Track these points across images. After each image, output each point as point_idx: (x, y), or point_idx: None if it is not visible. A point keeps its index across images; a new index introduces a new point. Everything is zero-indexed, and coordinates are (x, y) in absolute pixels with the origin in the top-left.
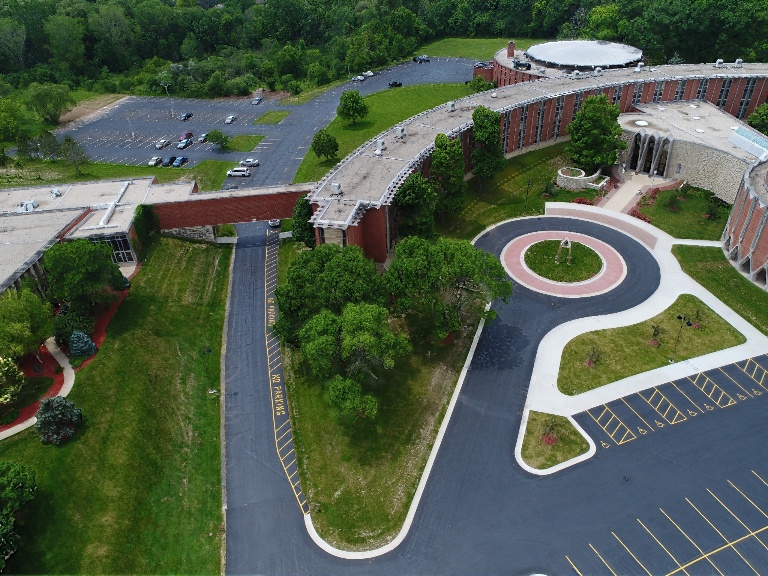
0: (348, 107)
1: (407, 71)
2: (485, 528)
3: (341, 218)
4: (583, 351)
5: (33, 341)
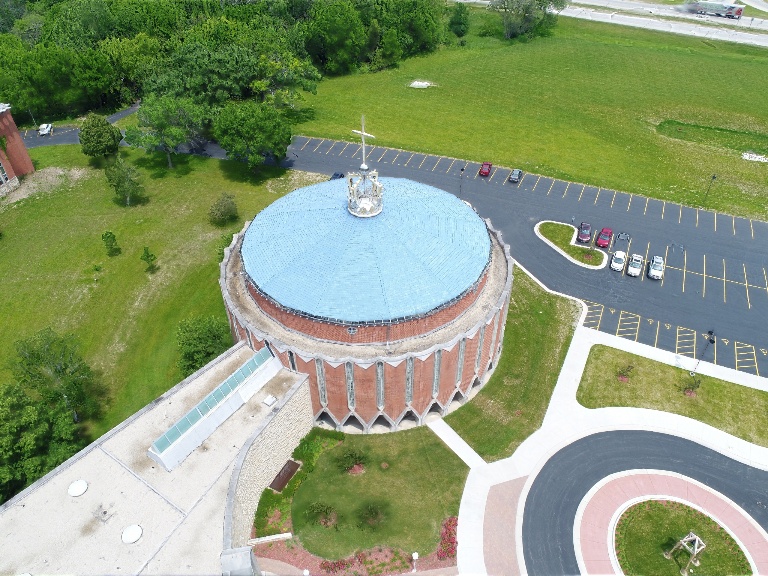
0: None
1: None
2: None
3: None
4: None
5: None
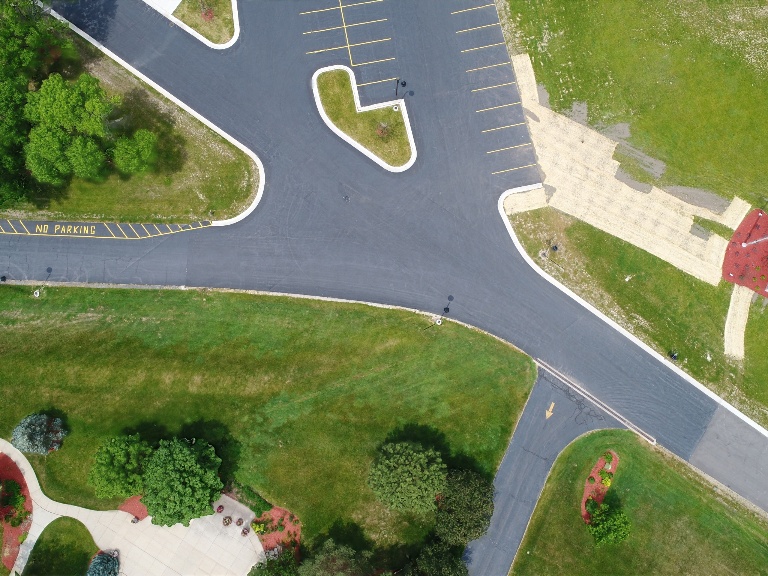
0: None
1: None
2: (268, 97)
3: None
4: None
5: None
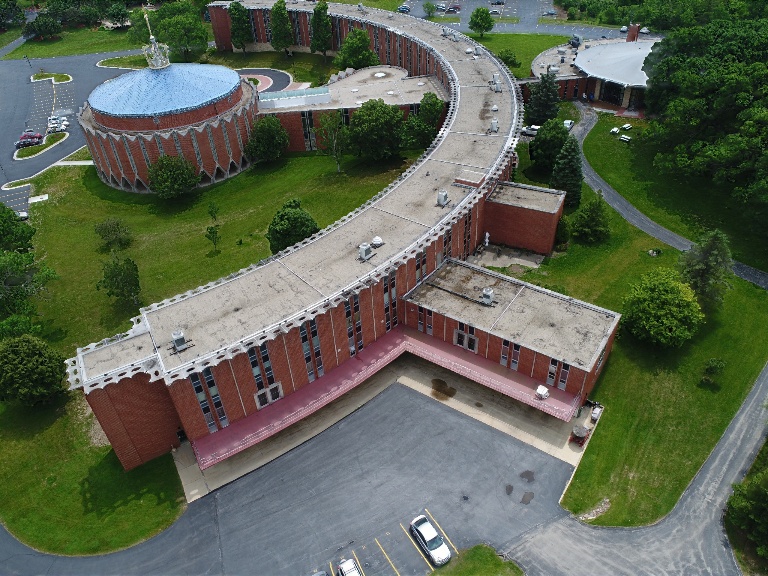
0: None
1: None
2: None
3: None
4: None
5: (200, 7)
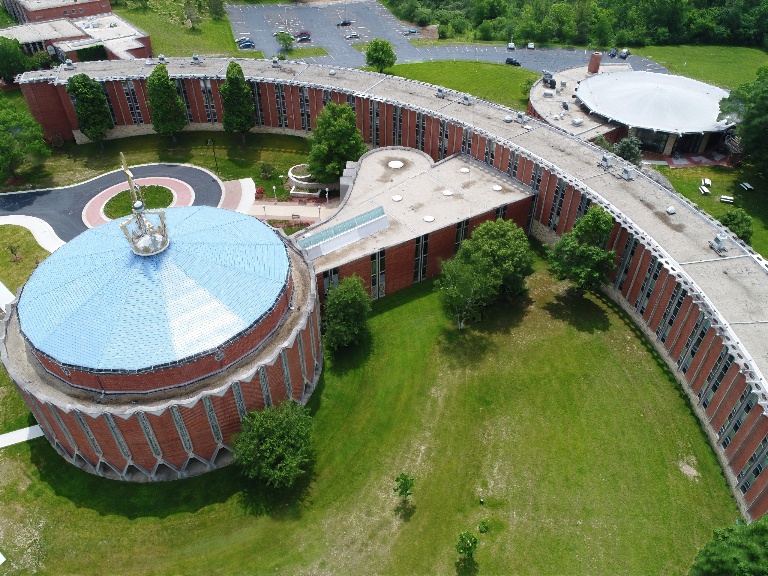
0: (368, 53)
1: (573, 57)
2: None
3: (29, 77)
4: (3, 232)
5: None
